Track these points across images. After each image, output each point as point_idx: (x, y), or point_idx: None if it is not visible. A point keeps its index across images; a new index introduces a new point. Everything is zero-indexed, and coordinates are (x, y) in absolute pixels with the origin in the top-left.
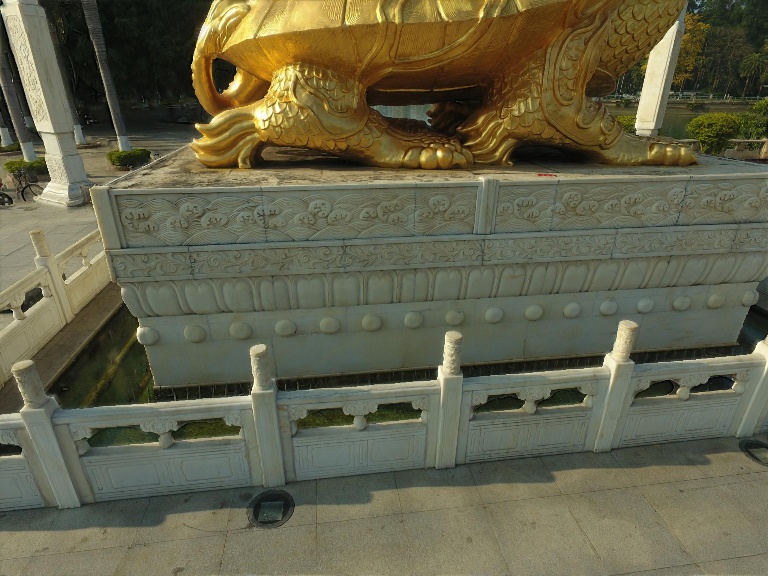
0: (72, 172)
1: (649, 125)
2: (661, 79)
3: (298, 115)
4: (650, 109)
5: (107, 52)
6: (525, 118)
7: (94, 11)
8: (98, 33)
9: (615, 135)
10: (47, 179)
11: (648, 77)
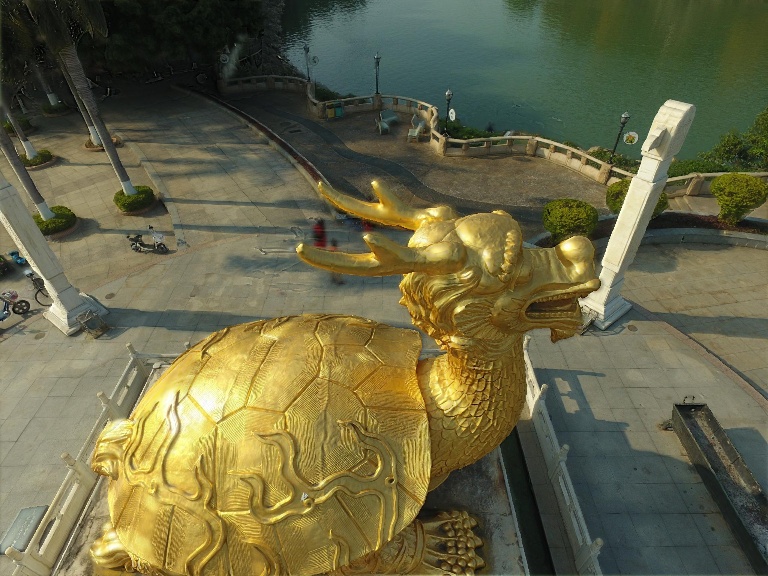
0: (68, 303)
1: (614, 268)
2: (629, 232)
3: (154, 572)
4: (616, 255)
5: (111, 38)
6: (329, 573)
7: (78, 72)
8: (86, 92)
9: (413, 567)
10: (63, 237)
11: (618, 225)
